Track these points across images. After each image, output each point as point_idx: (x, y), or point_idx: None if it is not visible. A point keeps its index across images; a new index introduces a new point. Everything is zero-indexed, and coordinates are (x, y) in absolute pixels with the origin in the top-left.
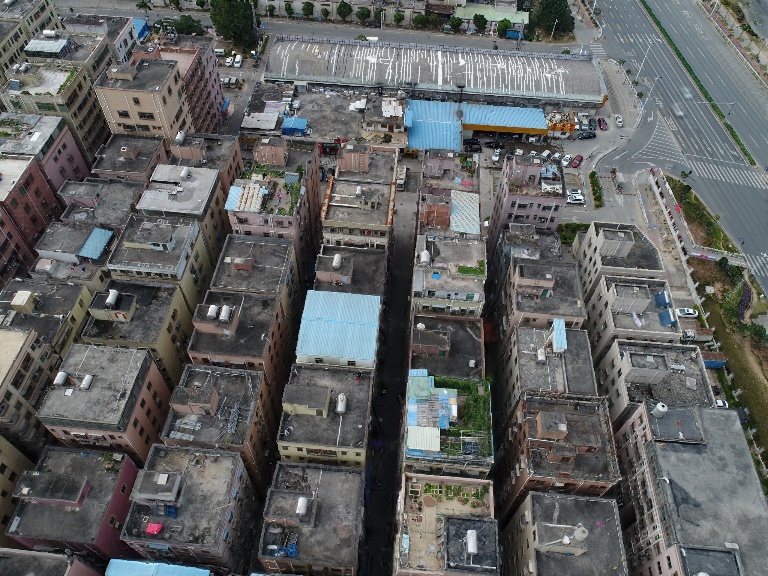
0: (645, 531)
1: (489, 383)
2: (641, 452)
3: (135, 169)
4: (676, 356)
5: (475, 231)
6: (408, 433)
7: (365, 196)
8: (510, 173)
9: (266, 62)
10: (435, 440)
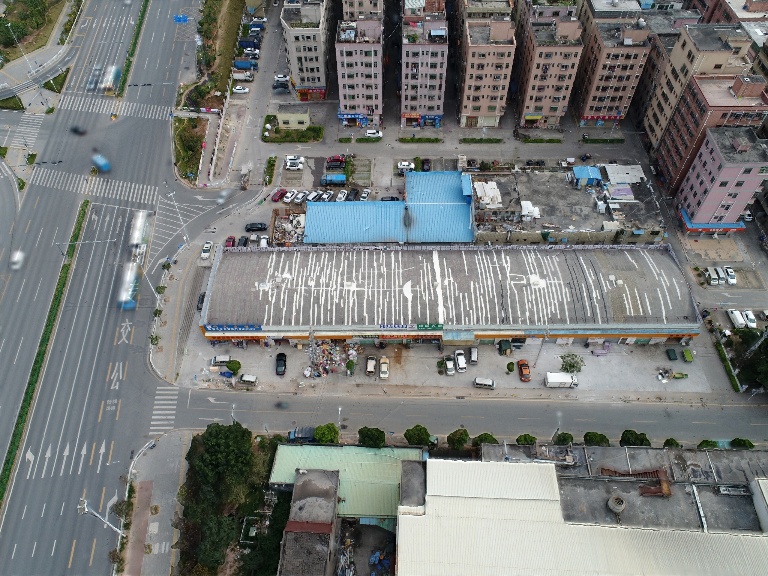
0: None
1: None
2: None
3: (668, 40)
4: None
5: None
6: None
7: None
8: None
9: None
10: None
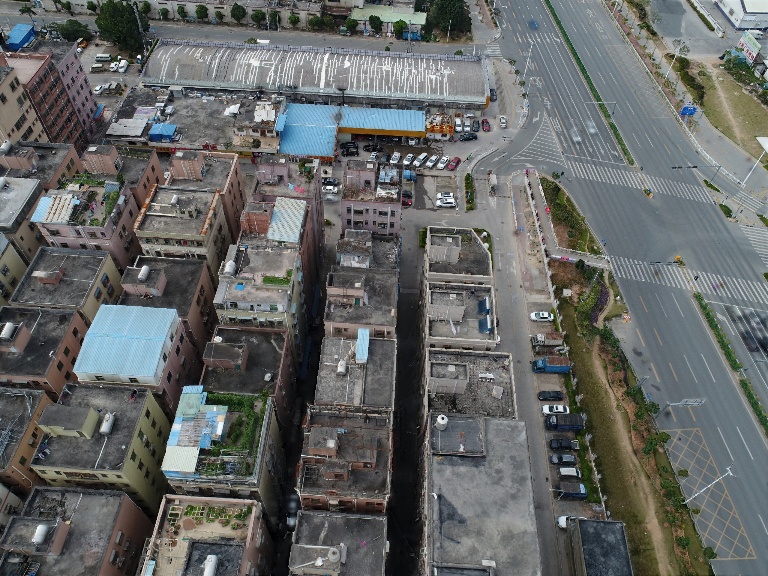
0: (423, 548)
1: (270, 398)
2: (426, 466)
3: None
4: (488, 364)
5: (293, 239)
6: (165, 454)
7: (181, 205)
8: (344, 178)
9: (144, 67)
10: (192, 460)
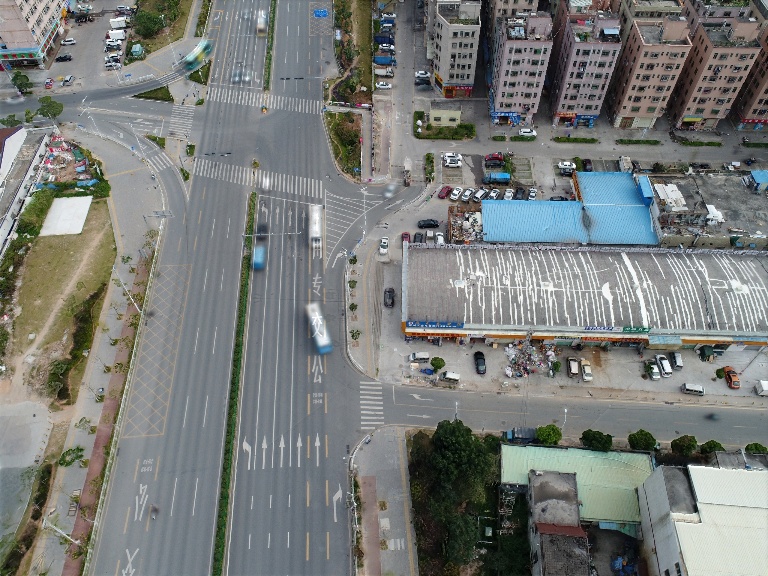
0: None
1: None
2: None
3: None
4: None
5: None
6: None
7: None
8: None
9: None
10: None
